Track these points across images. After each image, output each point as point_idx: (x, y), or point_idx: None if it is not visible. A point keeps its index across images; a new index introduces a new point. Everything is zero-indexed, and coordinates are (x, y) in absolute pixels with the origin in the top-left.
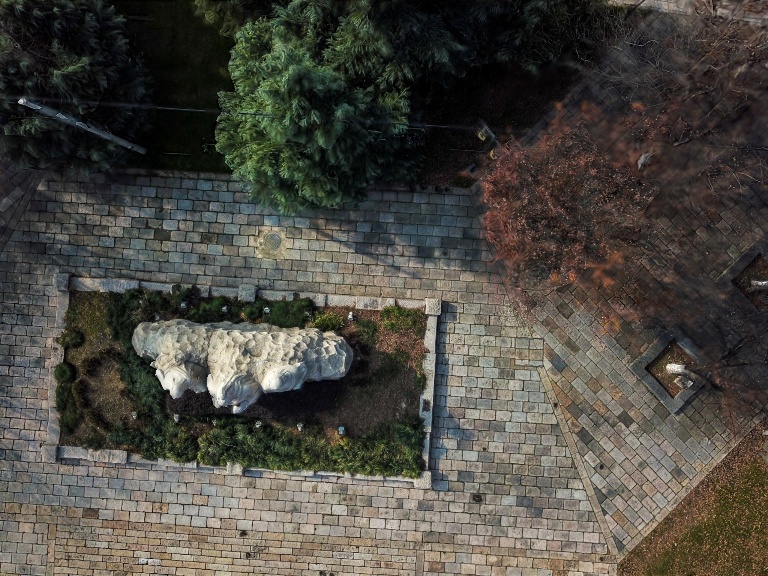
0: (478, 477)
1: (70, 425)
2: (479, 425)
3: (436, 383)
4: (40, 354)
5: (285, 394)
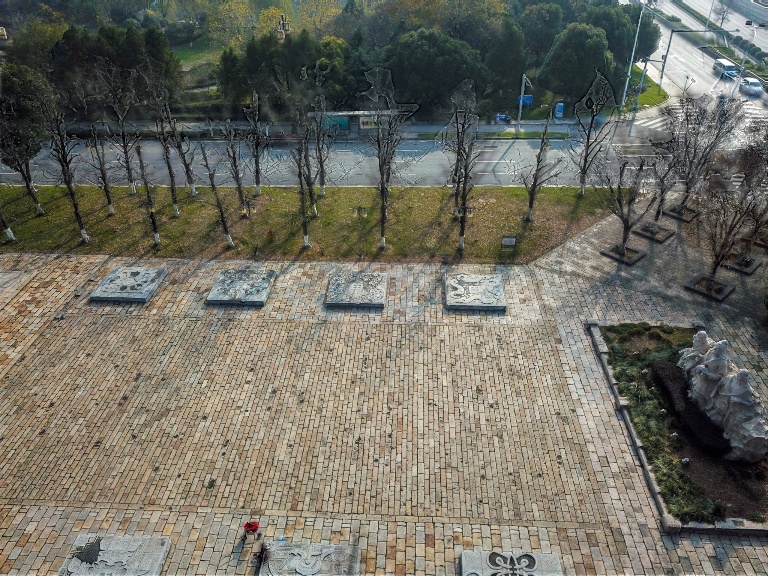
0: (691, 575)
1: (614, 329)
2: (742, 575)
3: (760, 537)
4: (646, 320)
5: (702, 418)
